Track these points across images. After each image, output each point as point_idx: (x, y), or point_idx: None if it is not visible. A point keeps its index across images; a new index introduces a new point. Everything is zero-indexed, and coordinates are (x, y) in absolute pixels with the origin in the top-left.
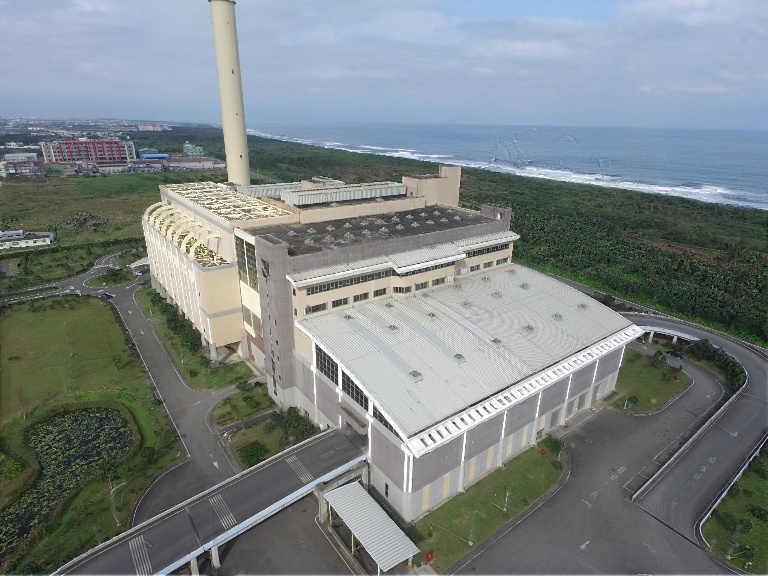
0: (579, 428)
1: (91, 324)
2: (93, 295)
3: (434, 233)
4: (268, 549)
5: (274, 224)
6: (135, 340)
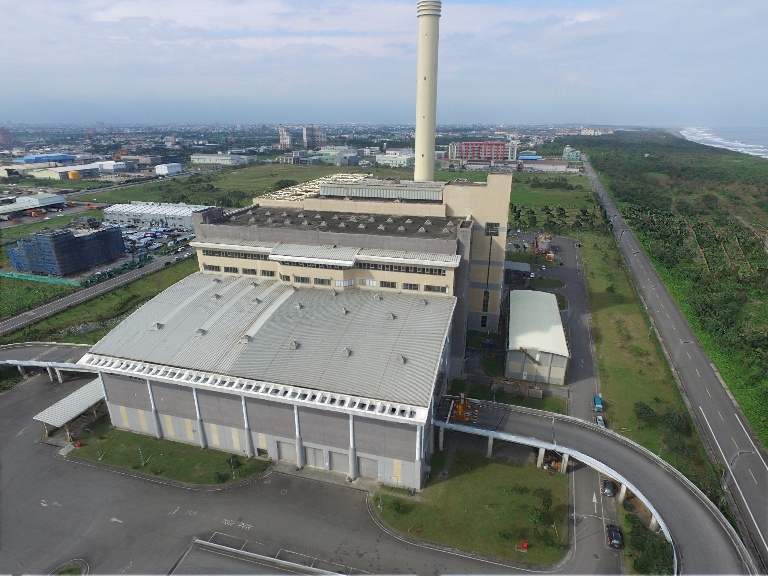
0: (304, 479)
1: None
2: None
3: (338, 234)
4: None
5: (285, 206)
6: None
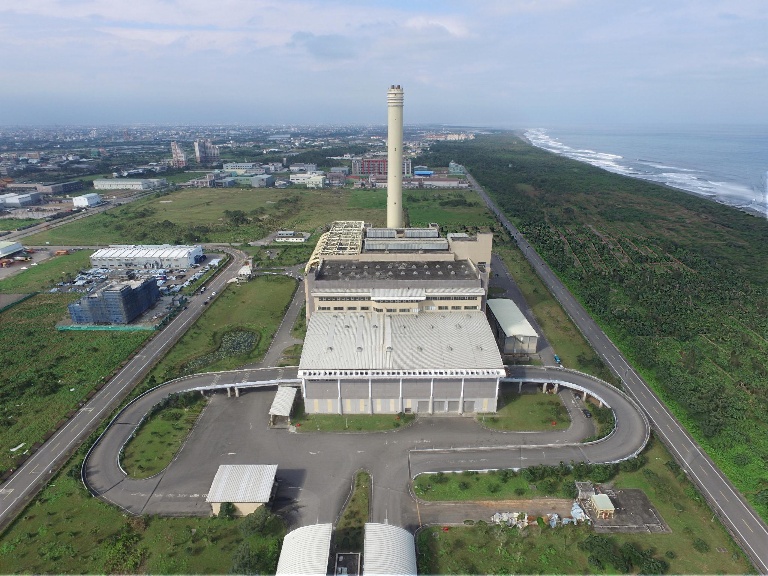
0: (438, 418)
1: (281, 293)
2: (296, 278)
3: (411, 281)
4: (256, 399)
5: (344, 259)
6: (291, 306)
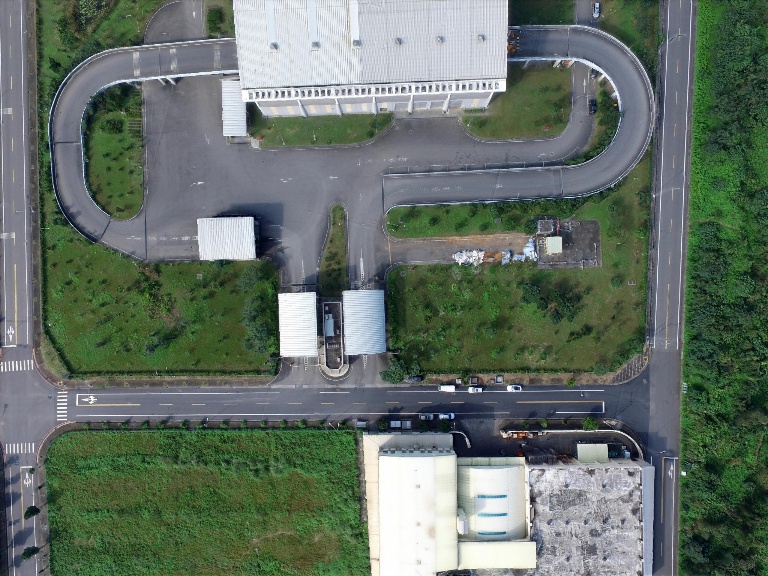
0: (417, 120)
1: None
2: None
3: None
4: (198, 88)
5: None
6: None
